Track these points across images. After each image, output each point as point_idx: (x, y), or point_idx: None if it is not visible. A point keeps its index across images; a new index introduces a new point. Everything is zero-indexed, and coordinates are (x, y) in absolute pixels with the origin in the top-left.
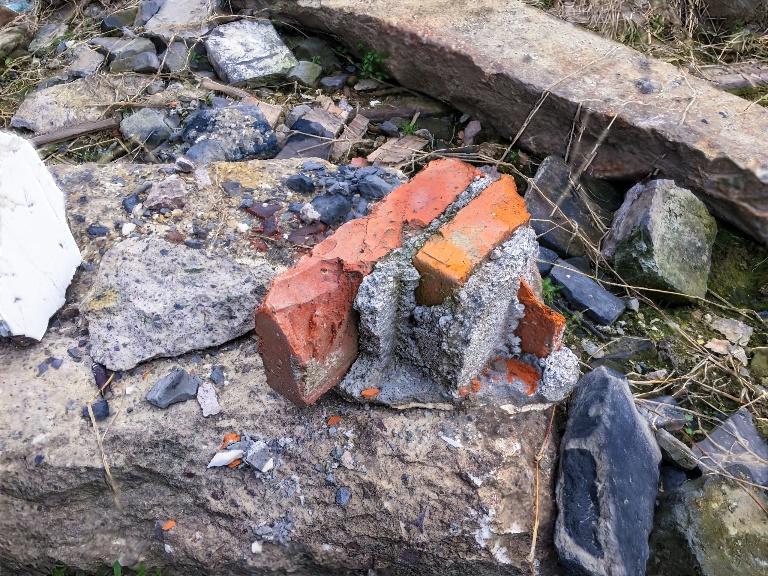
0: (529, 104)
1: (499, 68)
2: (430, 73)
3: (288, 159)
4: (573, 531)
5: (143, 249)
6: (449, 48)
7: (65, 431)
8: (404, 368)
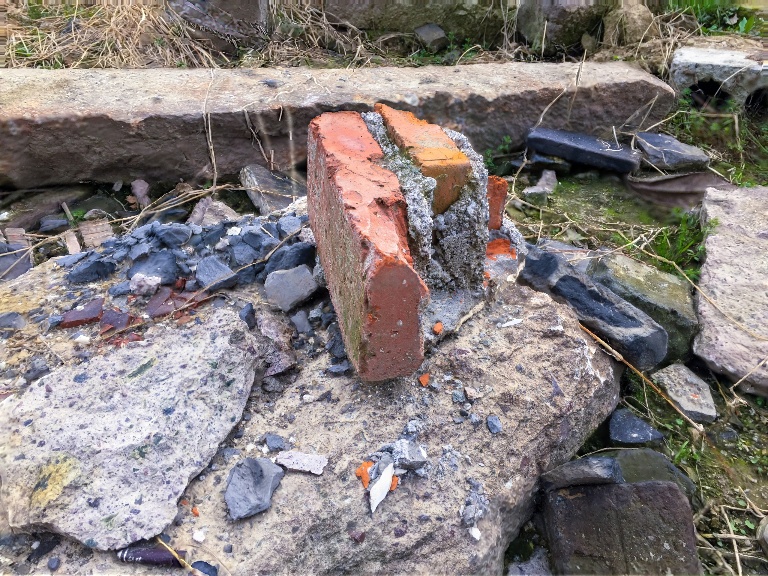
0: (191, 135)
1: (141, 115)
2: (57, 155)
3: (26, 272)
4: (616, 323)
5: (44, 395)
6: (74, 117)
7: None
8: (431, 299)
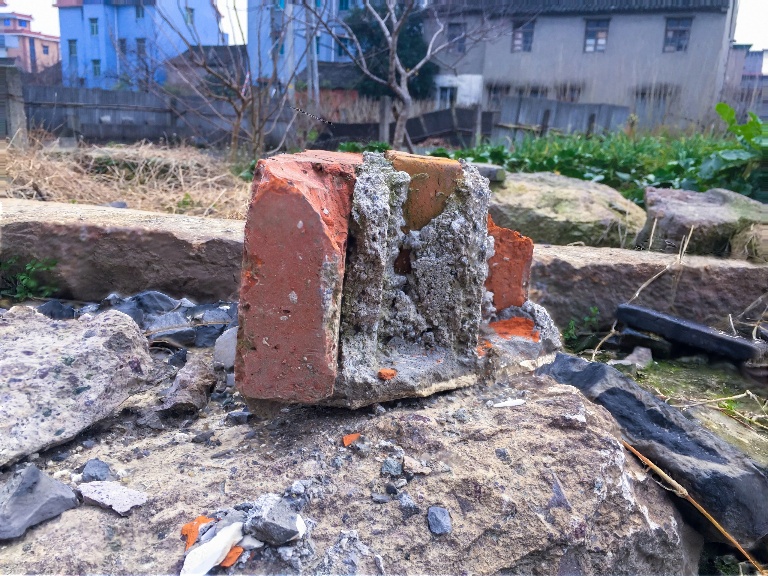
0: None
1: (206, 238)
2: (118, 268)
3: None
4: (684, 451)
5: None
6: (142, 230)
7: None
8: (397, 351)
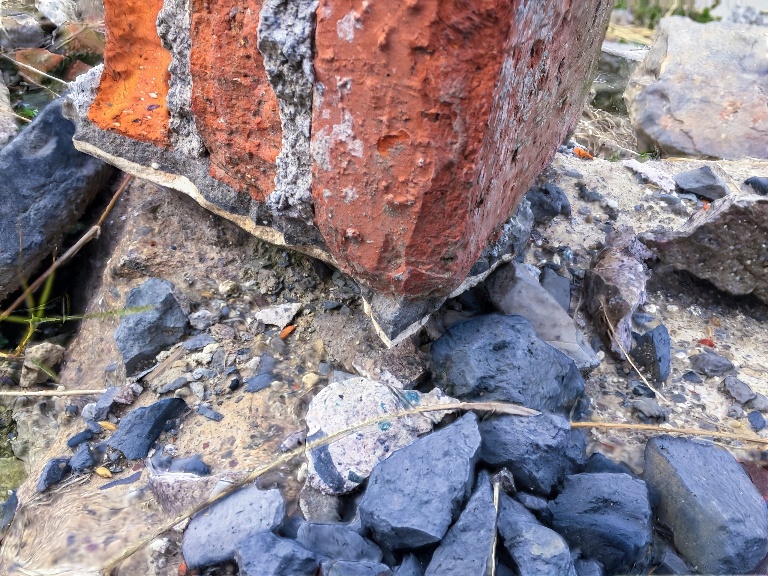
0: None
1: None
2: None
3: None
4: None
5: None
6: None
7: (766, 171)
8: None
